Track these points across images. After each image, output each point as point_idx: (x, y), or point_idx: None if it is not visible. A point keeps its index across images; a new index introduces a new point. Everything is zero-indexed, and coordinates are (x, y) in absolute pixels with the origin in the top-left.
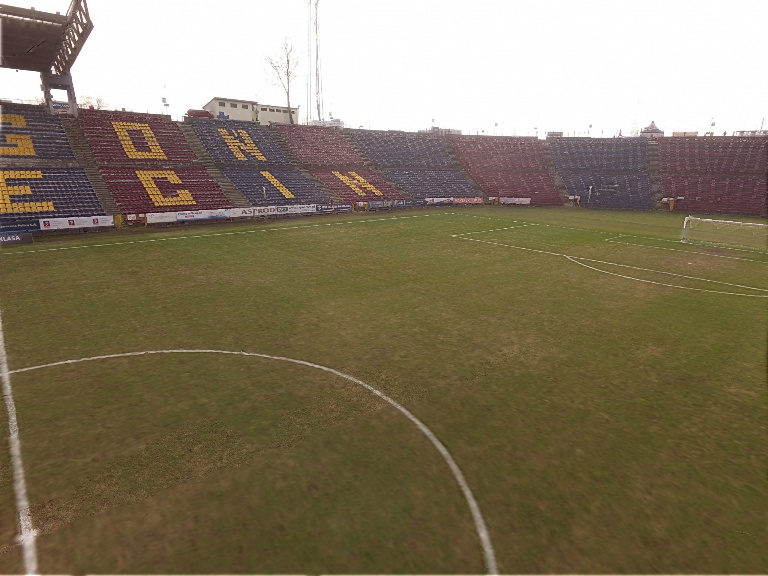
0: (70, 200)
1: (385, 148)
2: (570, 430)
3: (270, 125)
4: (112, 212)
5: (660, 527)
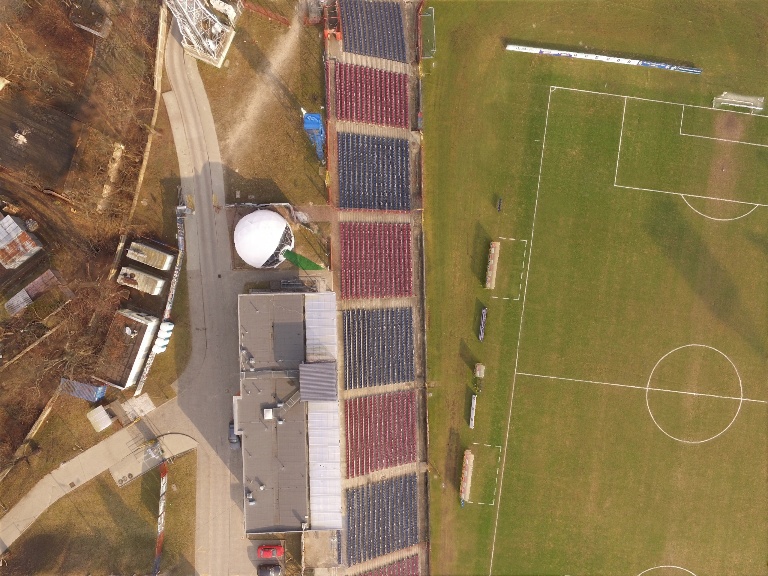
0: None
1: None
2: (660, 454)
3: None
4: None
5: (645, 442)
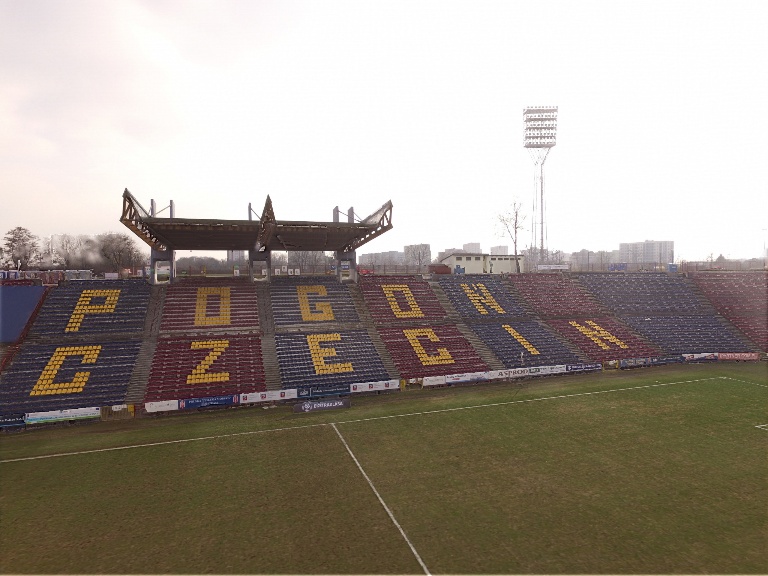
0: (362, 361)
1: (619, 291)
2: None
3: (502, 275)
4: (392, 372)
5: None
